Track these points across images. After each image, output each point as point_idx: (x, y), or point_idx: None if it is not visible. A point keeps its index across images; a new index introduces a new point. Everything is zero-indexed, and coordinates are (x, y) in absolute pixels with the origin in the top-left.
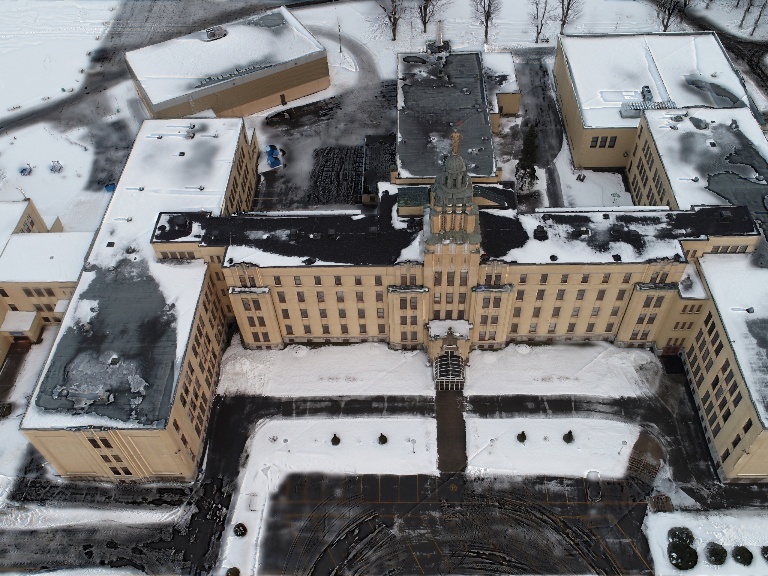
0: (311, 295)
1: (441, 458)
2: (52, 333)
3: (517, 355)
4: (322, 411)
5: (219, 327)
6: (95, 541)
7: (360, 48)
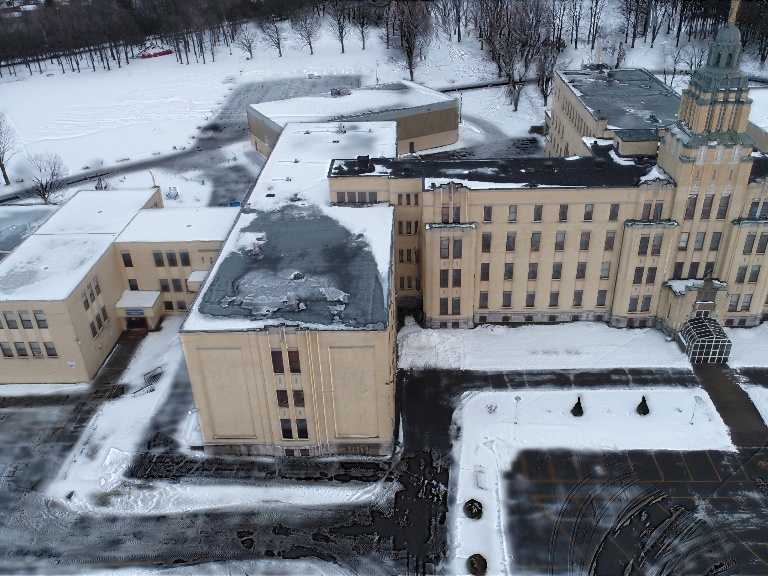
0: (524, 238)
1: (733, 429)
2: (174, 321)
3: None
4: (546, 383)
5: (396, 295)
6: (255, 526)
7: (479, 120)
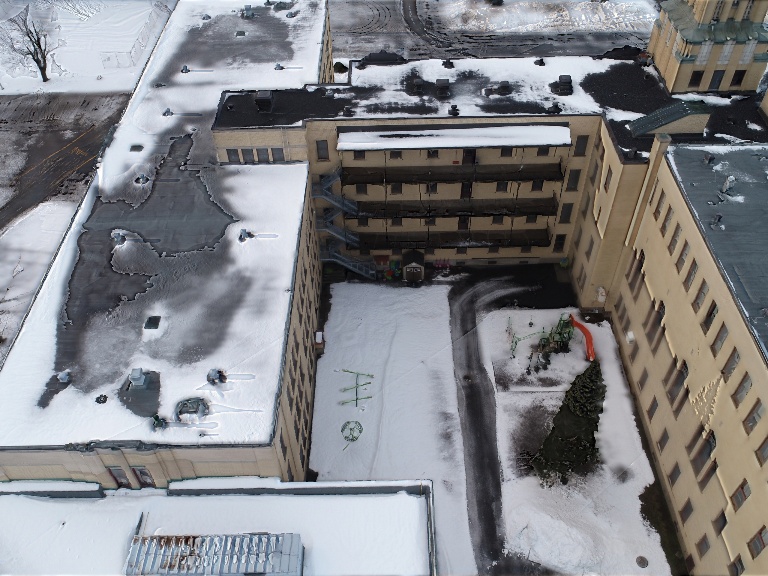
0: None
1: None
2: None
3: None
4: None
5: None
6: None
7: None
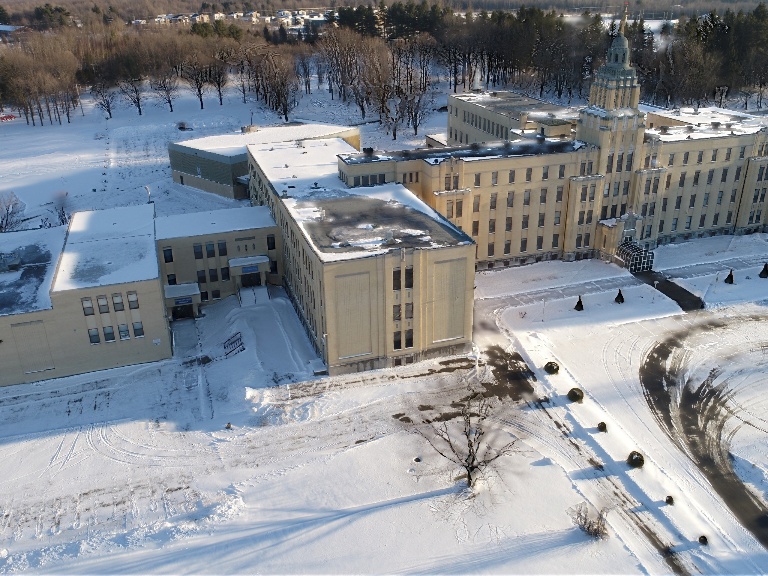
0: (503, 198)
1: (679, 302)
2: (213, 308)
3: (671, 249)
4: (546, 297)
5: None
6: (403, 410)
7: None
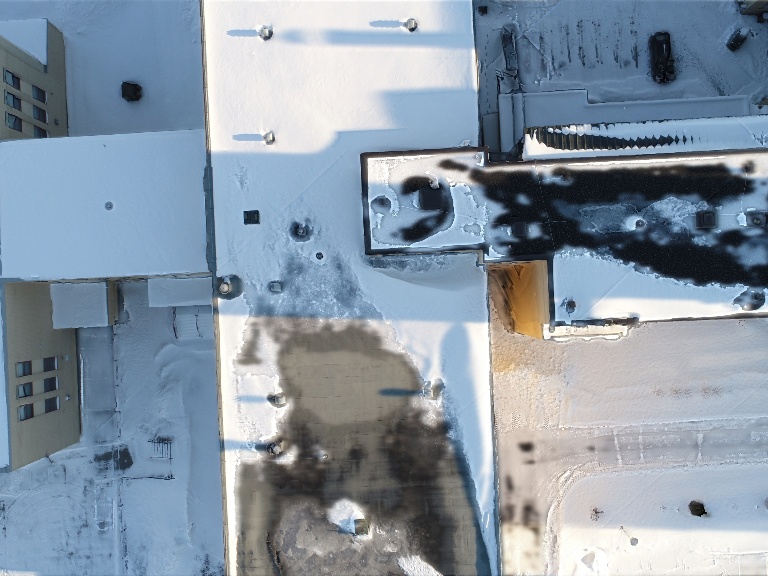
0: None
1: None
2: (140, 300)
3: None
4: (666, 453)
5: None
6: None
7: None
